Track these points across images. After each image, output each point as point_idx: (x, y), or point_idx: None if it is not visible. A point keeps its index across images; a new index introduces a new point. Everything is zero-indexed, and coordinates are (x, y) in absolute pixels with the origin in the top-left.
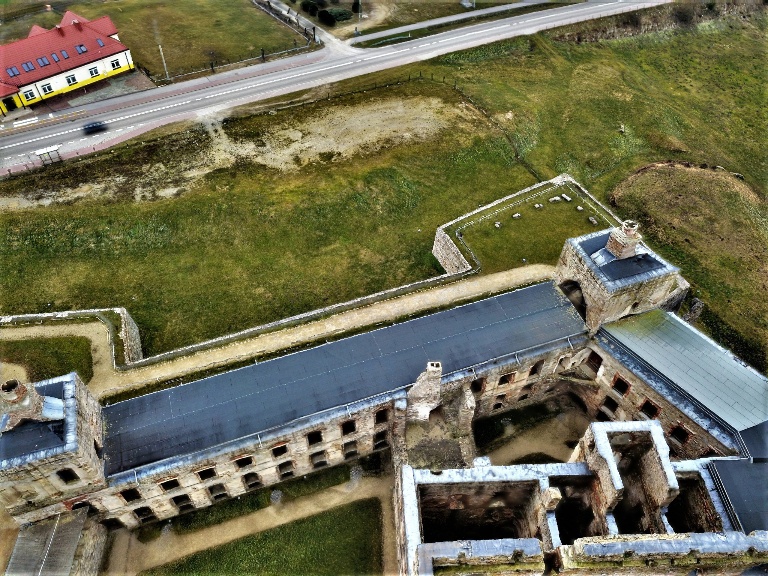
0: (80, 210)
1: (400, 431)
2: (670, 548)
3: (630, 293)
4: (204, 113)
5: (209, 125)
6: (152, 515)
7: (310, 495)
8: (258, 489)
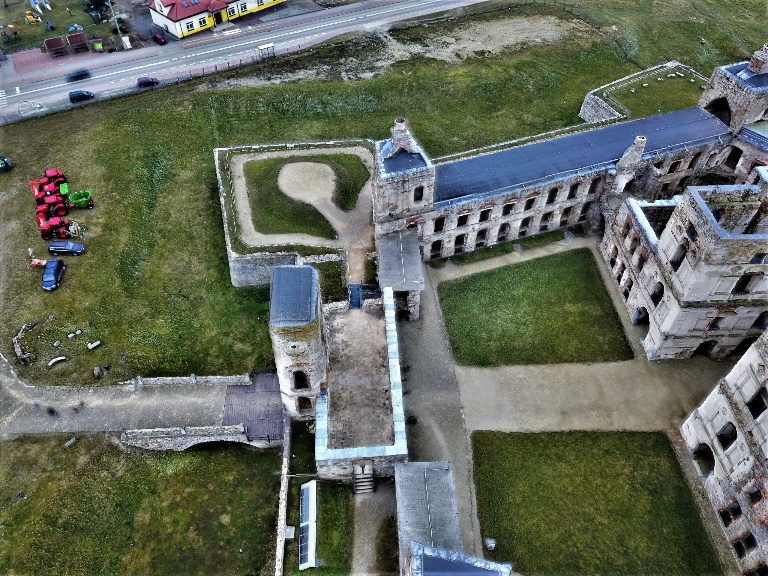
0: (305, 86)
1: (604, 199)
2: None
3: (766, 98)
4: (370, 26)
5: (379, 33)
6: (438, 252)
7: (540, 246)
8: (503, 242)
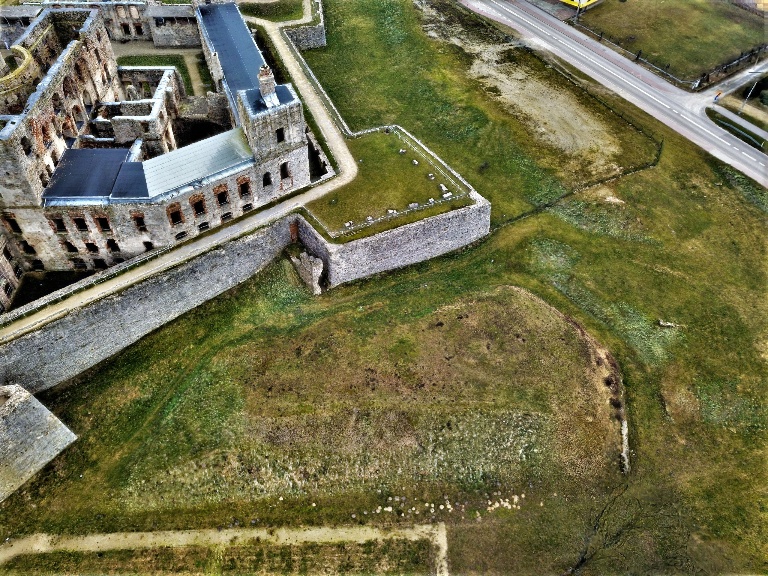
0: (410, 11)
1: None
2: None
3: None
4: (535, 40)
5: (518, 43)
6: None
7: (205, 94)
8: None
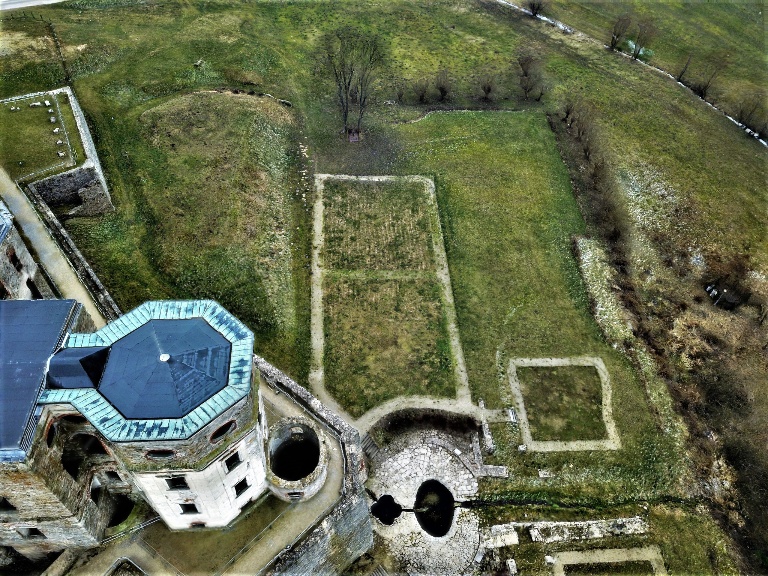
0: None
1: None
2: None
3: None
4: None
5: None
6: None
7: None
8: None
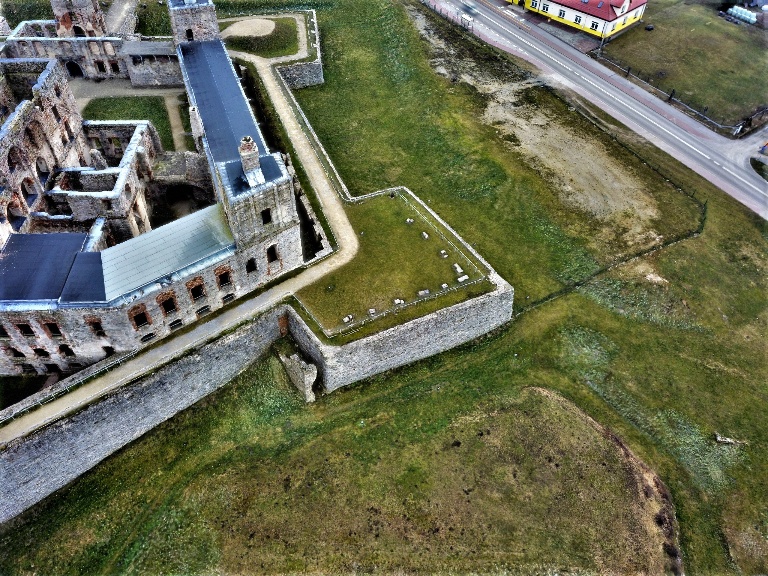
0: (416, 43)
1: None
2: (6, 122)
3: None
4: (555, 77)
5: (537, 80)
6: None
7: (186, 144)
8: None
